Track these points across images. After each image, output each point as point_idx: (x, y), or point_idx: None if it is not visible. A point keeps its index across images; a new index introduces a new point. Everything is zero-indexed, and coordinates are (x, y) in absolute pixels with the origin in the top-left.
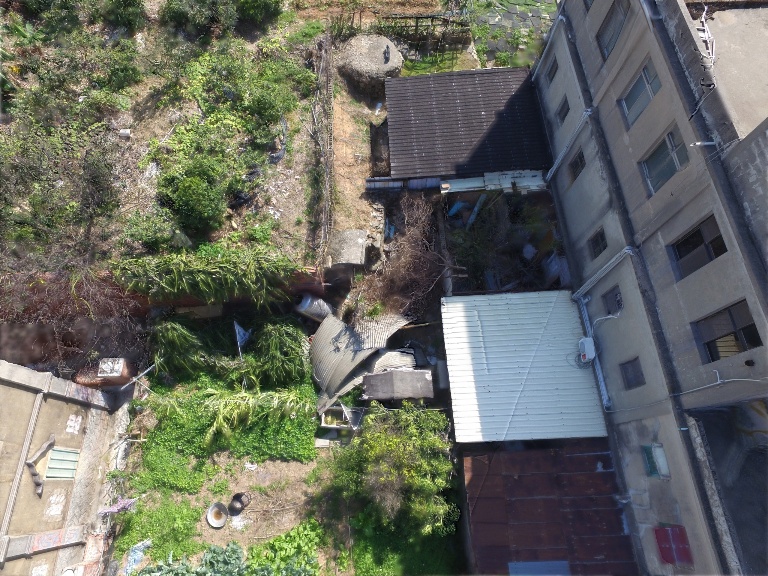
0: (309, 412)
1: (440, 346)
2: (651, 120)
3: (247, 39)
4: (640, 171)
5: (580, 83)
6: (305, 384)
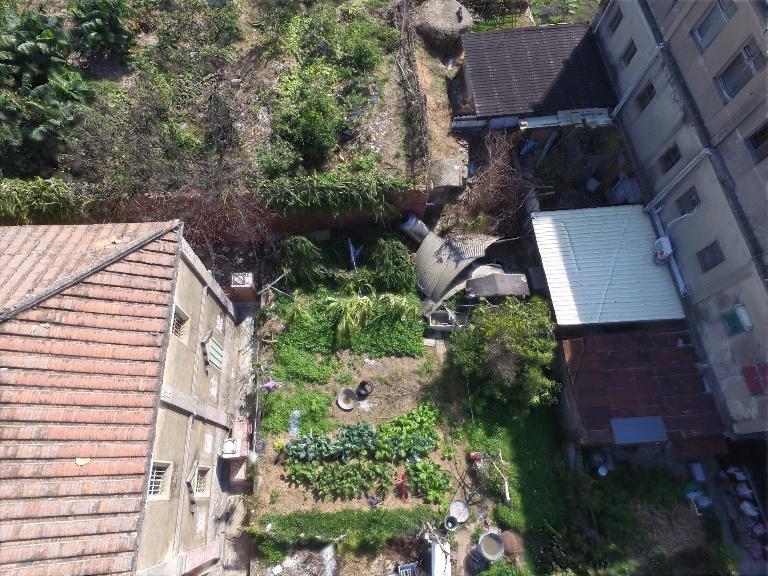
0: (417, 315)
1: (524, 261)
2: (728, 39)
3: (331, 4)
4: (716, 84)
5: (650, 24)
6: (411, 293)
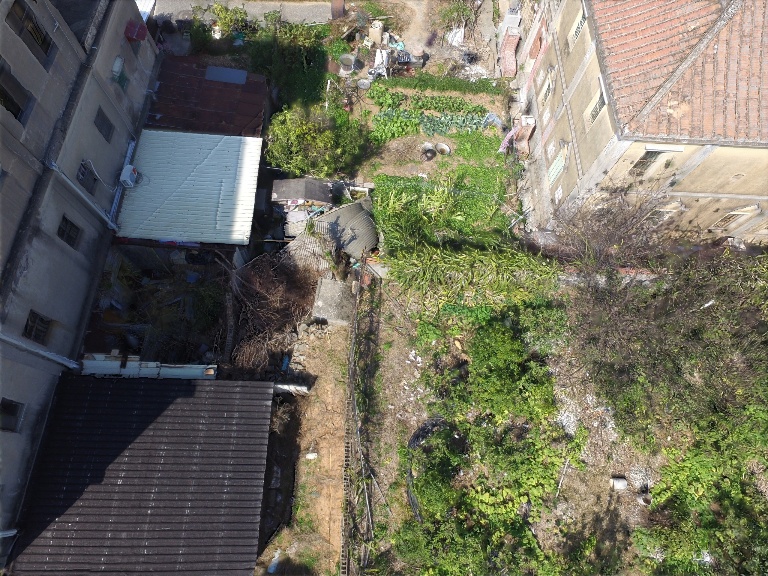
0: None
1: (259, 243)
2: None
3: None
4: None
5: None
6: None
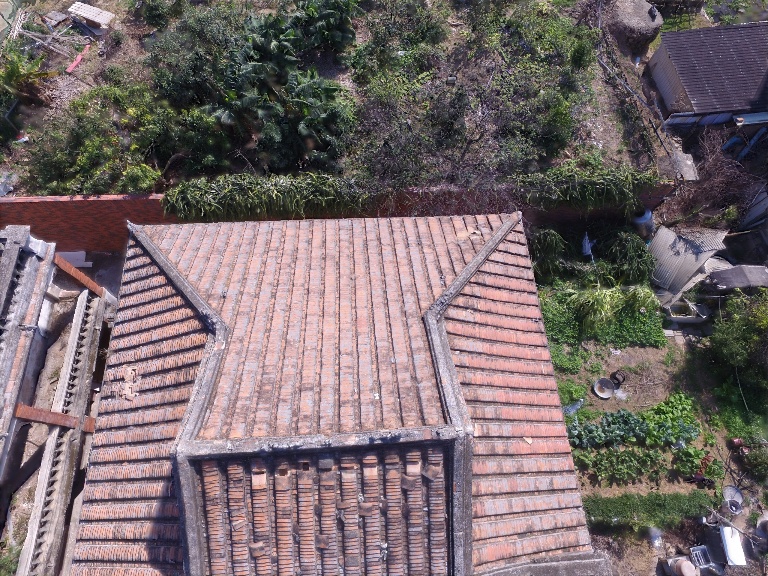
0: (655, 307)
1: (745, 254)
2: None
3: (518, 3)
4: None
5: None
6: None
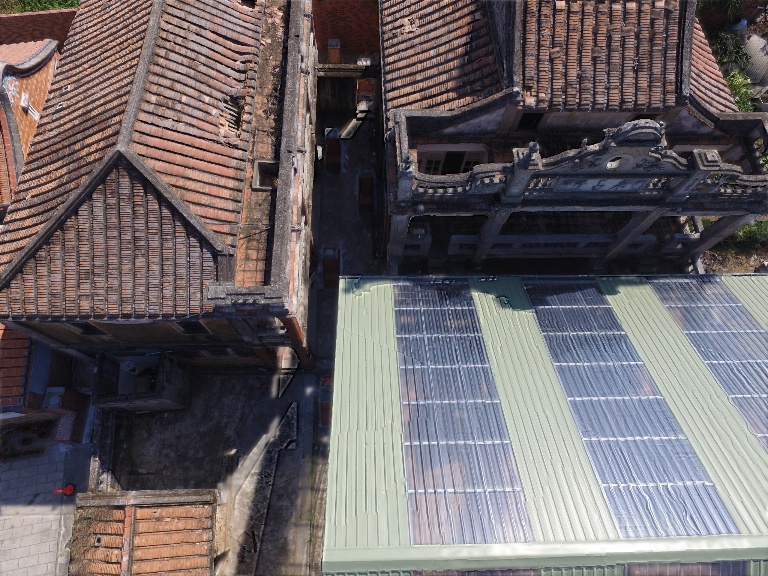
0: (748, 98)
1: None
2: None
3: None
4: None
5: None
6: None
